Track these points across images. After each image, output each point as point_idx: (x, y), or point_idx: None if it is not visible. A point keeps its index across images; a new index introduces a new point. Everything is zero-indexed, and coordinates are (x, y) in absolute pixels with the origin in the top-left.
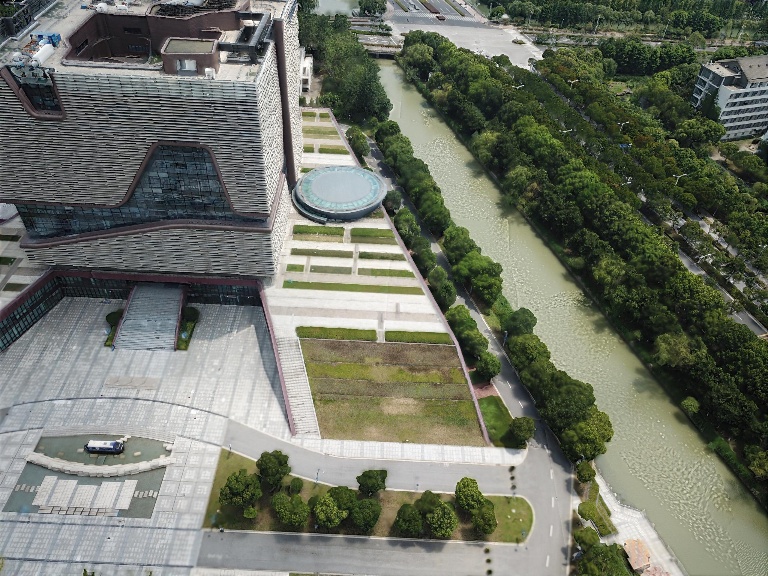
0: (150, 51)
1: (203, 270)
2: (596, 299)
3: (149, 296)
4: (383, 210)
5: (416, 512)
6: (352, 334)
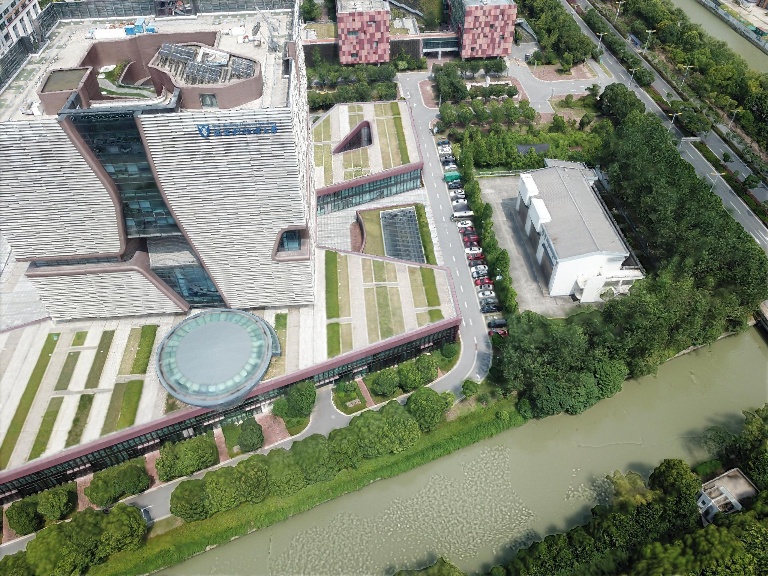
0: None
1: None
2: None
3: None
4: None
5: None
6: None
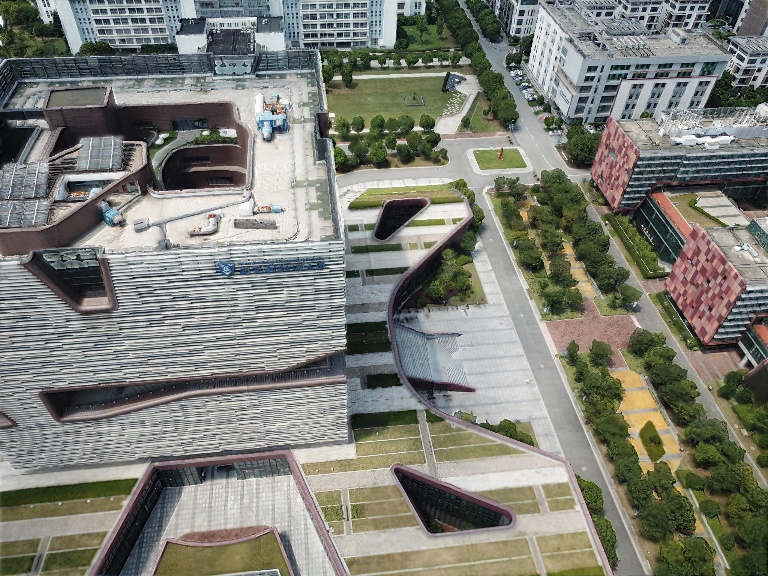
0: (164, 187)
1: None
2: None
3: None
4: None
5: None
6: None
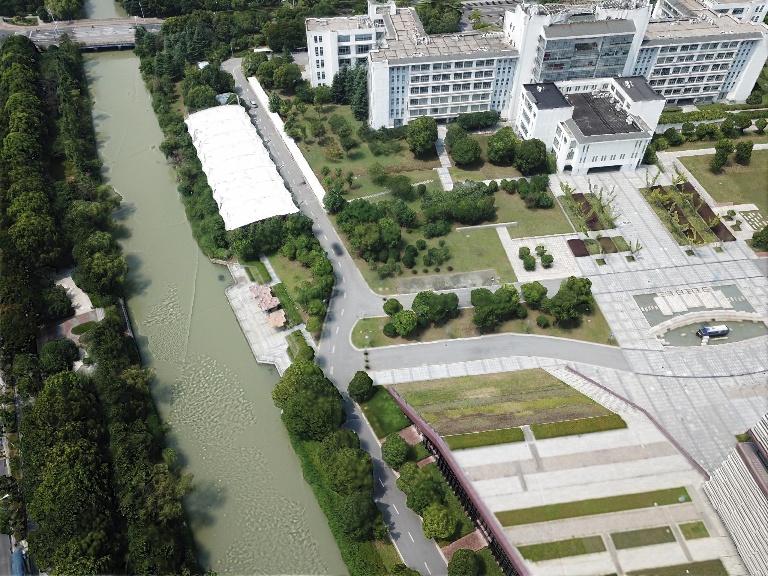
0: None
1: None
2: None
3: None
4: None
5: (445, 295)
6: (561, 427)
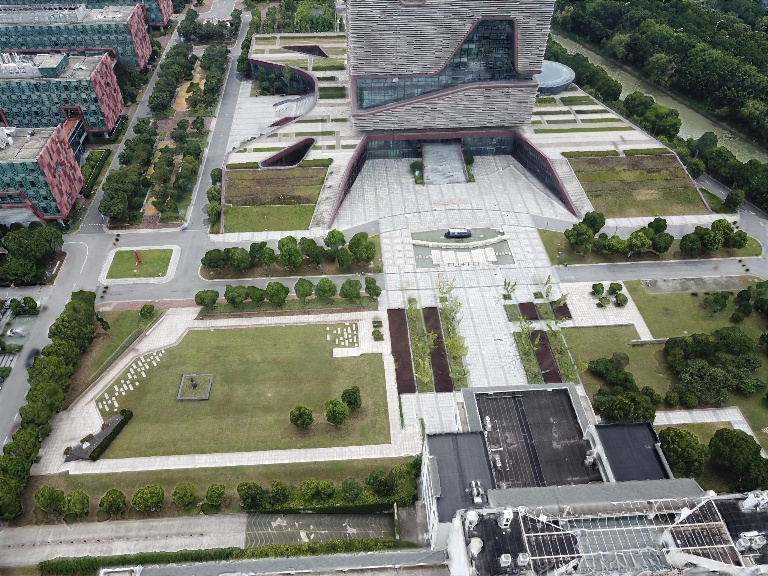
0: None
1: (479, 124)
2: (742, 134)
3: (435, 150)
4: (576, 85)
5: (697, 236)
6: (602, 153)
